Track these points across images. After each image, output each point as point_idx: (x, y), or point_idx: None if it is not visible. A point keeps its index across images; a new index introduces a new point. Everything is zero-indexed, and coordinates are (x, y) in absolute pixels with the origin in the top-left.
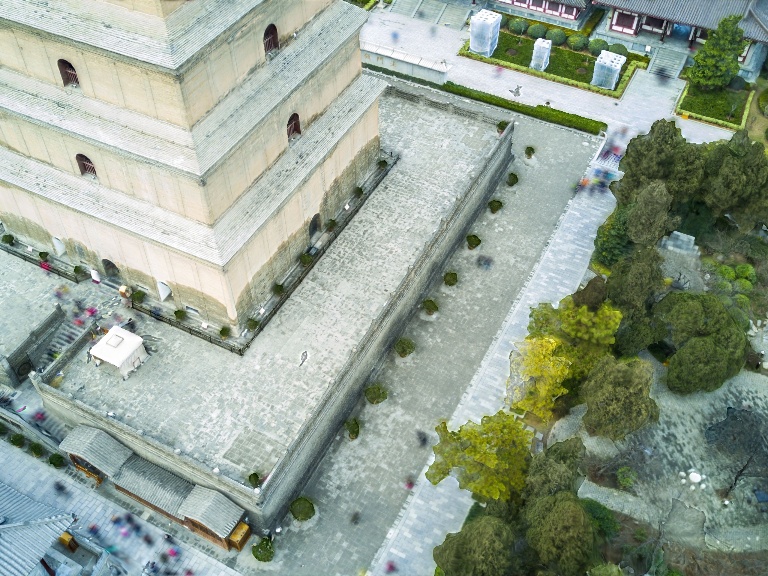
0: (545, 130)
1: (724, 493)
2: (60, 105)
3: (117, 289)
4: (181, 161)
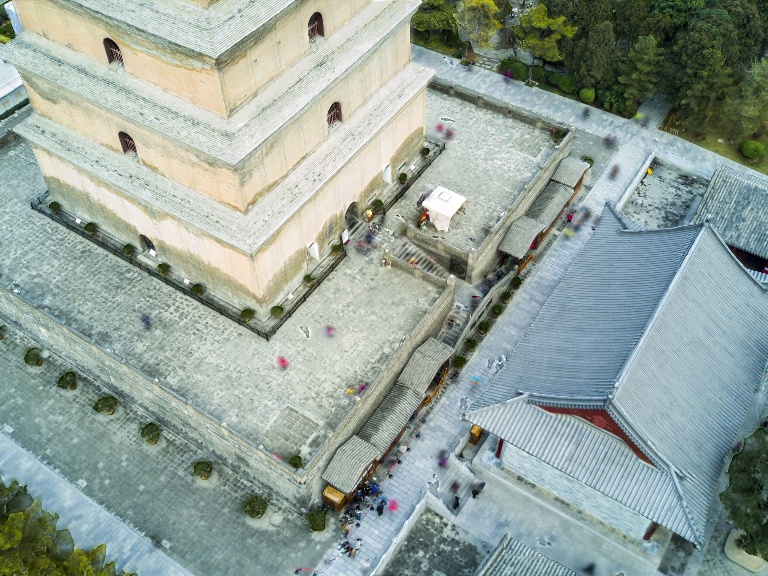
0: None
1: (523, 6)
2: (321, 64)
3: (361, 225)
4: (409, 6)
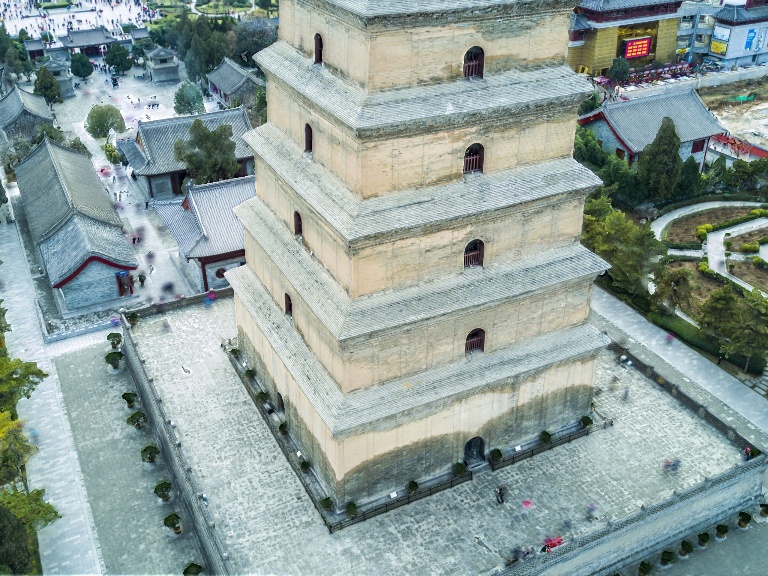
0: None
1: None
2: None
3: None
4: None
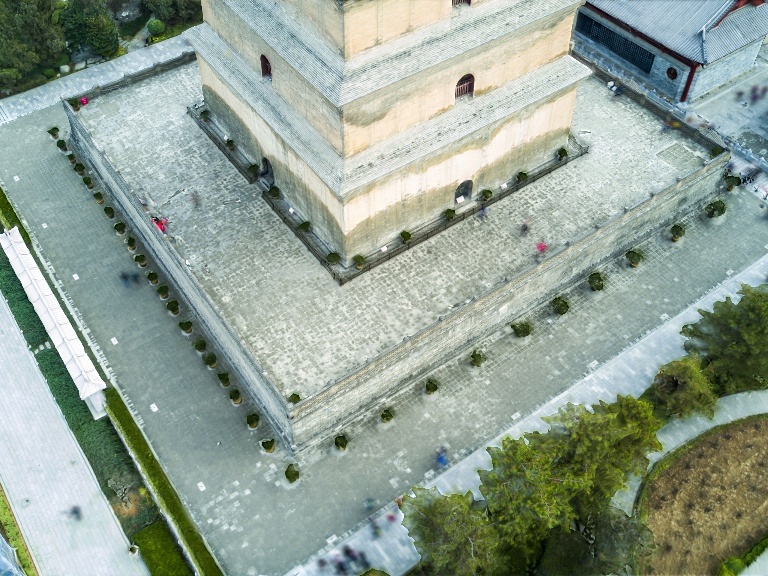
0: (4, 161)
1: None
2: None
3: None
4: None
